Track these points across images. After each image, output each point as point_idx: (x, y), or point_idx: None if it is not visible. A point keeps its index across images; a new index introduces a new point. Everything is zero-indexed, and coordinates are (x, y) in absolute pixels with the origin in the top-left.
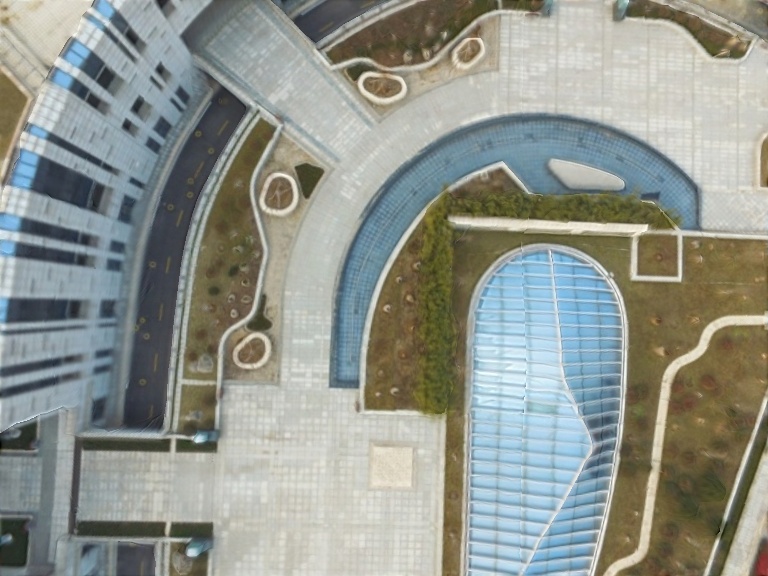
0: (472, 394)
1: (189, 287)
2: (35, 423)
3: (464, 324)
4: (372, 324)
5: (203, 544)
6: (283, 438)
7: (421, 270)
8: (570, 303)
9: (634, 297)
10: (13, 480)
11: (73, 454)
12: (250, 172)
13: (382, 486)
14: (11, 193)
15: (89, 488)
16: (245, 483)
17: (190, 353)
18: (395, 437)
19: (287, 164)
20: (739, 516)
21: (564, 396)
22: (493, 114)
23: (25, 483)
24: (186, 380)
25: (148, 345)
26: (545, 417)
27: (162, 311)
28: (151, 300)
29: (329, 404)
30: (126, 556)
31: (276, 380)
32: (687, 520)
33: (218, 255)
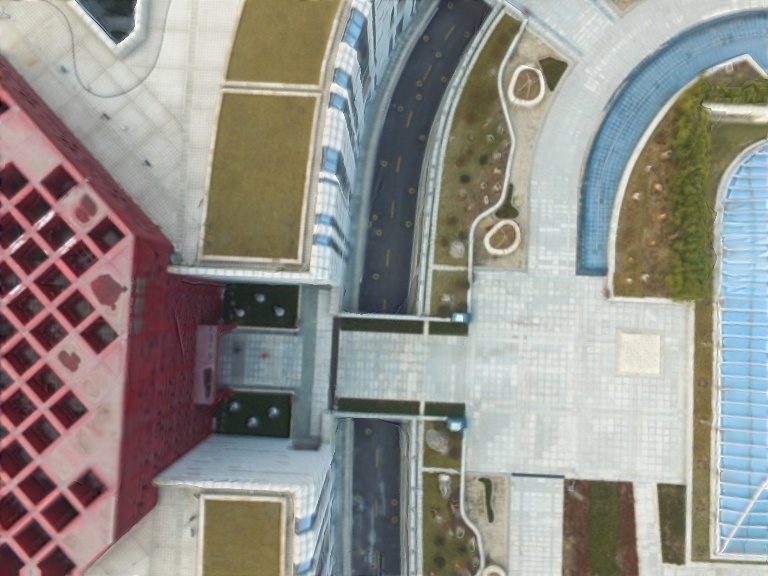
0: (721, 282)
1: (439, 176)
2: (296, 303)
3: None
4: (620, 212)
5: (460, 421)
6: (532, 323)
7: (675, 157)
8: None
9: None
10: (276, 357)
11: (331, 334)
12: (498, 65)
13: (630, 372)
14: (346, 50)
15: (347, 367)
16: (495, 366)
17: (441, 239)
18: (642, 325)
19: (531, 58)
20: None
21: None
22: (734, 9)
23: (287, 360)
24: (437, 265)
25: (380, 241)
26: None
27: (393, 208)
28: (383, 198)
29: (576, 291)
30: (362, 443)
31: (524, 267)
32: None
33: (468, 145)
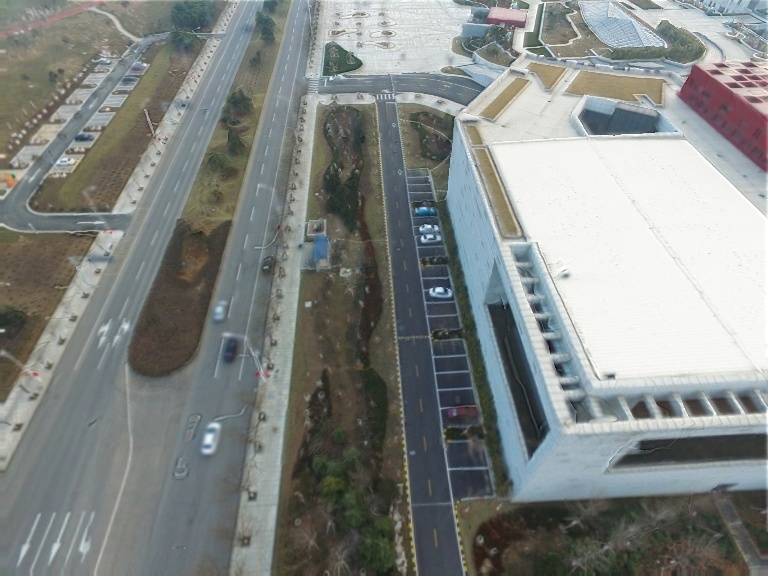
0: None
1: None
2: None
3: None
4: None
5: (709, 11)
6: None
7: None
8: None
9: None
10: None
11: None
12: None
13: None
14: None
15: None
16: (706, 20)
17: None
18: None
19: None
20: None
21: None
22: None
23: None
24: None
25: None
26: None
27: None
28: None
29: None
30: None
31: None
32: None
33: None
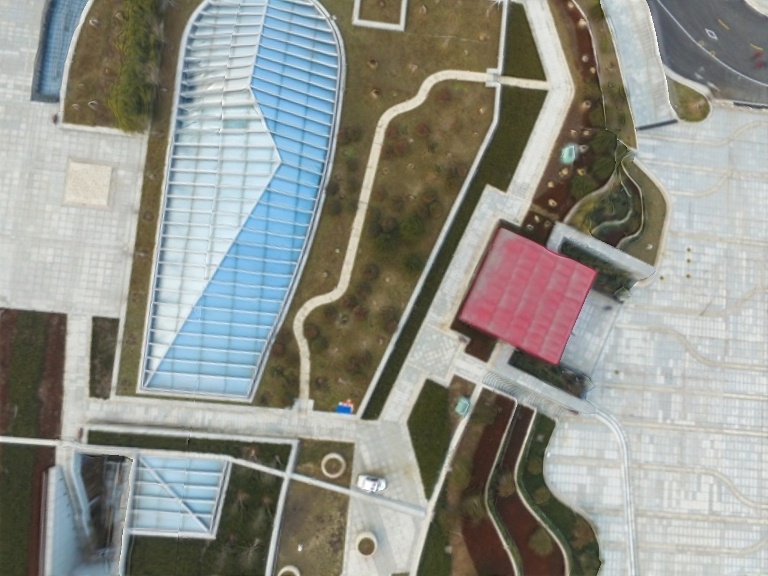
0: (176, 117)
1: None
2: None
3: (176, 49)
4: (78, 39)
5: None
6: None
7: None
8: (281, 32)
9: (356, 42)
10: None
11: None
12: None
13: (76, 202)
14: None
15: None
16: None
17: None
18: (95, 156)
19: None
20: (446, 267)
21: (252, 107)
22: None
23: None
24: None
25: None
26: (239, 135)
27: None
28: None
29: (29, 117)
30: None
31: None
32: (385, 258)
33: None
